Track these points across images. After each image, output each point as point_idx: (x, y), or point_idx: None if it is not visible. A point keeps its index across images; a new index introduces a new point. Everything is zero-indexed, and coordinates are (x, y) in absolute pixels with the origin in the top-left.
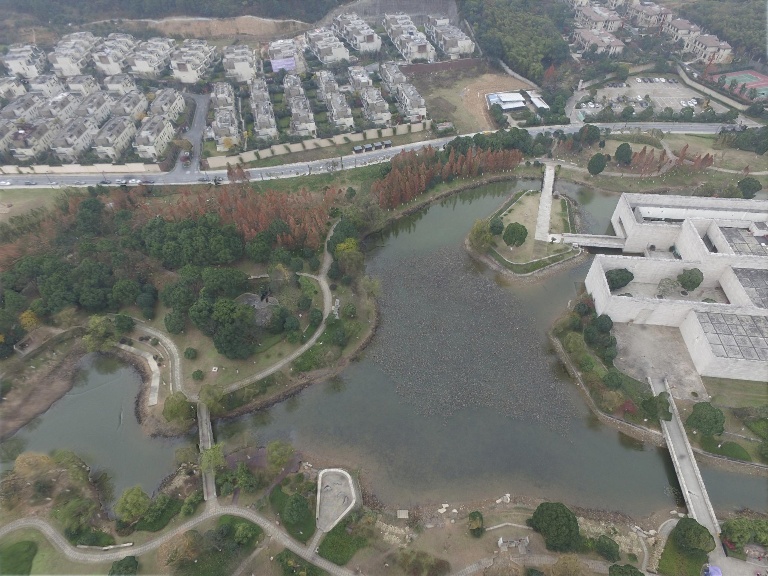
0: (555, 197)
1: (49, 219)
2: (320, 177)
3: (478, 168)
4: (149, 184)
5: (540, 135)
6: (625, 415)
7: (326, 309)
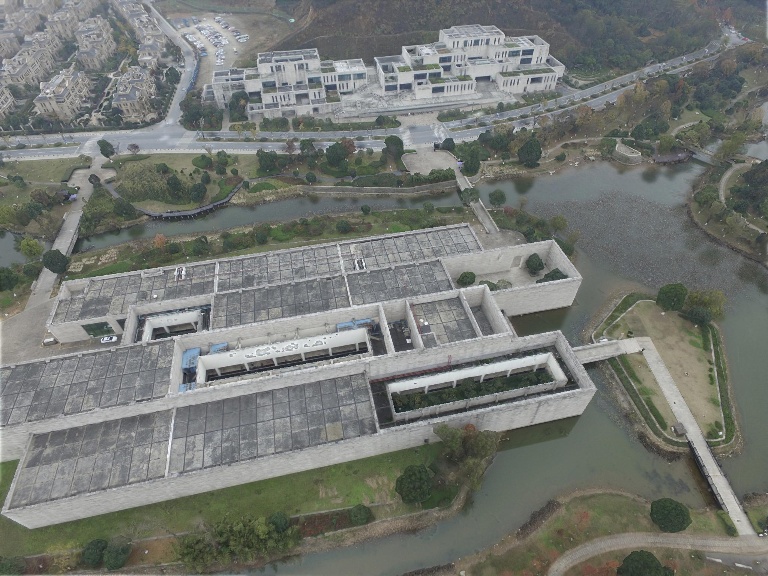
0: None
1: None
2: None
3: None
4: None
5: None
6: None
7: None
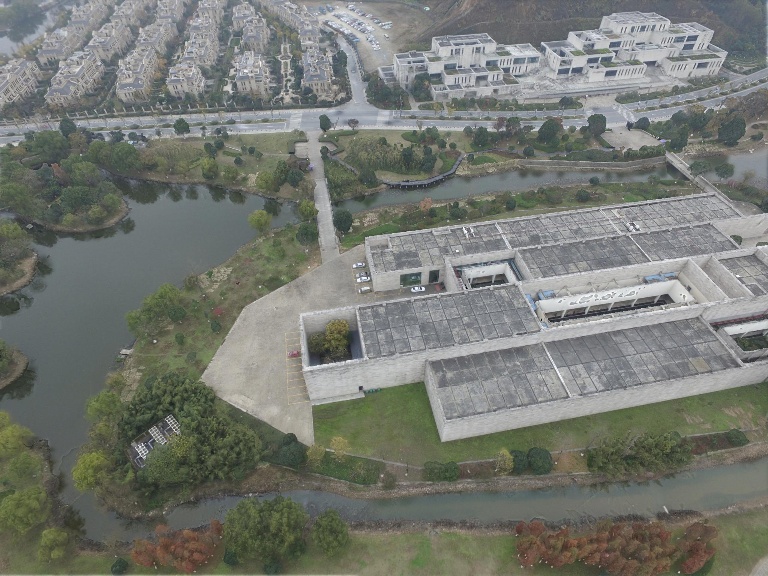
0: None
1: None
2: None
3: None
4: None
5: None
6: None
7: None
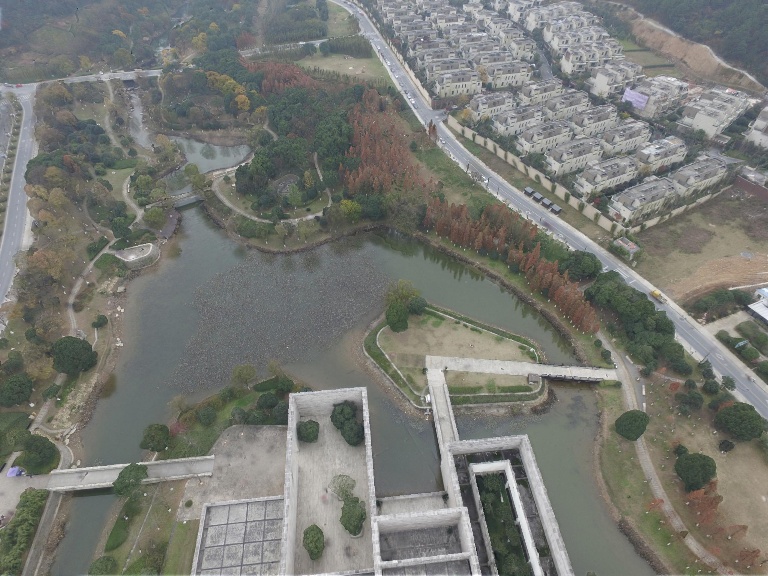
0: (528, 377)
1: (349, 85)
2: (464, 179)
3: (545, 287)
4: (411, 107)
5: (674, 345)
6: None
7: None
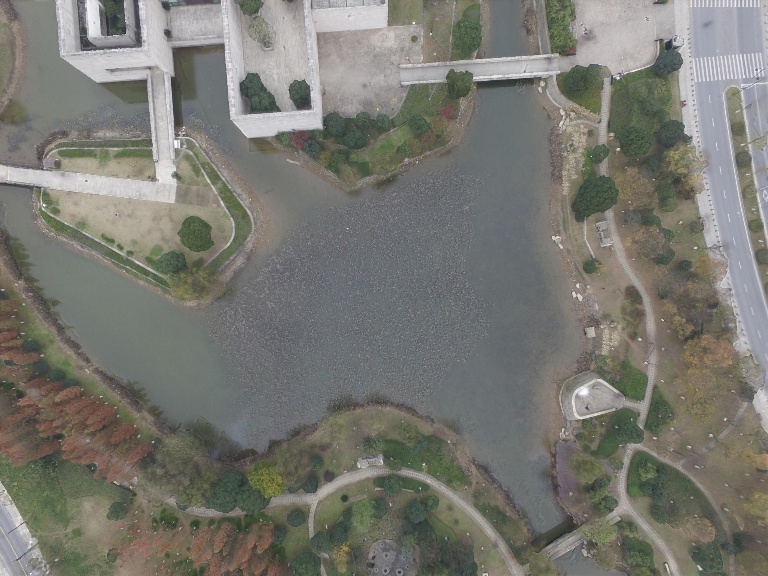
0: (57, 166)
1: None
2: None
3: None
4: None
5: None
6: (452, 117)
7: (368, 475)
